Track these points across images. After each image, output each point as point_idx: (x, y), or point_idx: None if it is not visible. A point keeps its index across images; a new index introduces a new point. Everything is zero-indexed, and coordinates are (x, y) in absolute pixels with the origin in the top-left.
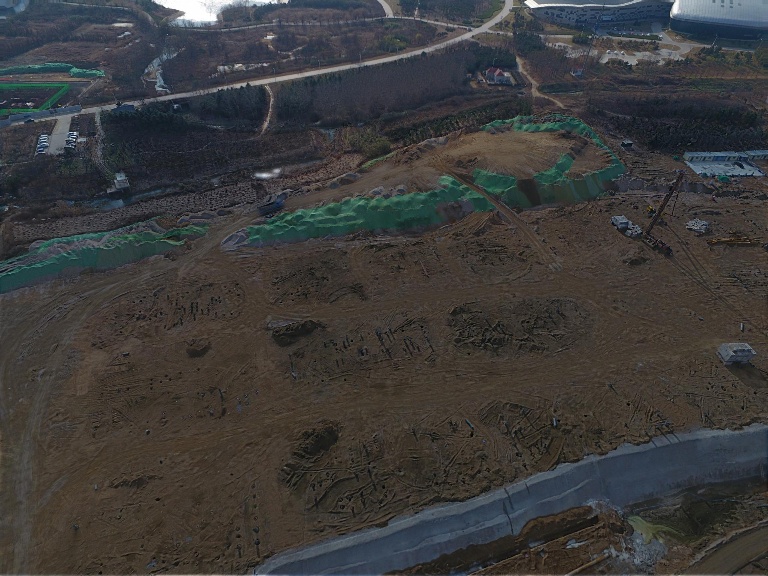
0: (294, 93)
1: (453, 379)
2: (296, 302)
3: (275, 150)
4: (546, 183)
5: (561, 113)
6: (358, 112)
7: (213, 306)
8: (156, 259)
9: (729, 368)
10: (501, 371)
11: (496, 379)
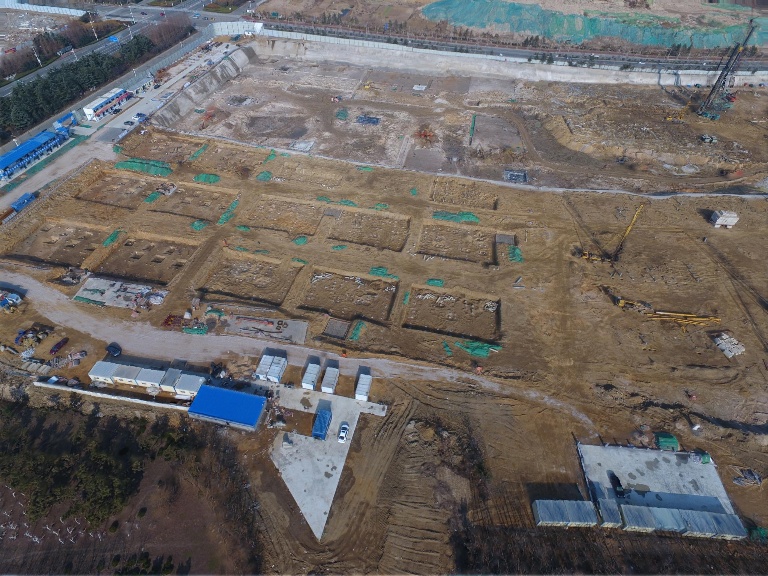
0: None
1: None
2: None
3: None
4: None
5: None
6: None
7: None
8: None
9: None
10: None
11: None
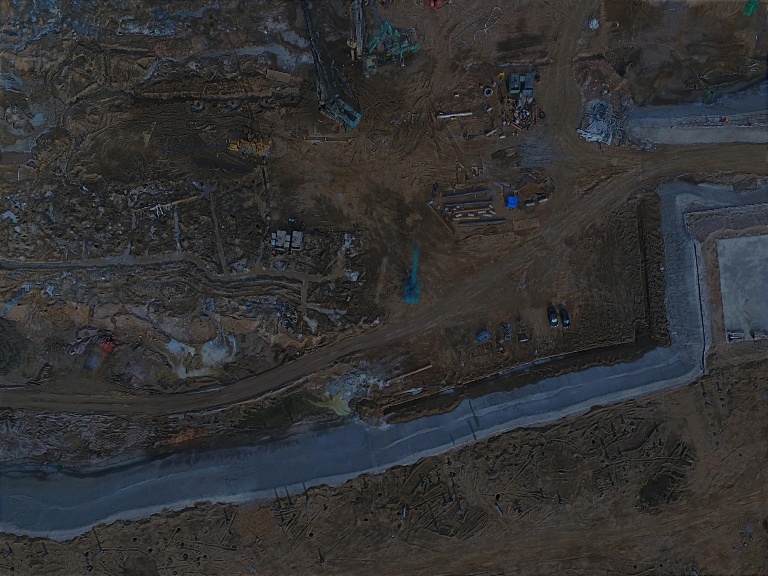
0: None
1: (509, 569)
2: None
3: None
4: None
5: None
6: None
7: None
8: None
9: None
10: None
11: (457, 569)
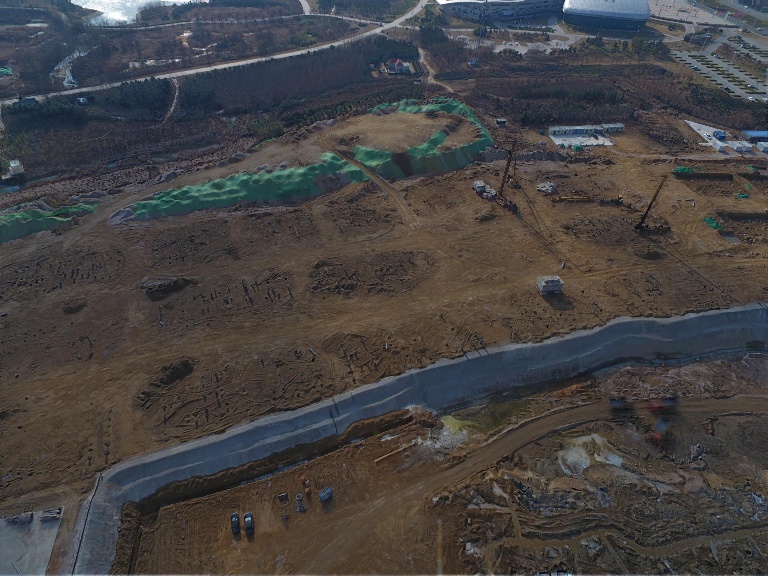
0: (197, 84)
1: (305, 318)
2: (173, 264)
3: (174, 136)
4: (418, 156)
5: (448, 97)
6: (260, 101)
7: (93, 271)
8: (43, 234)
9: (544, 297)
10: (349, 310)
11: (343, 316)
